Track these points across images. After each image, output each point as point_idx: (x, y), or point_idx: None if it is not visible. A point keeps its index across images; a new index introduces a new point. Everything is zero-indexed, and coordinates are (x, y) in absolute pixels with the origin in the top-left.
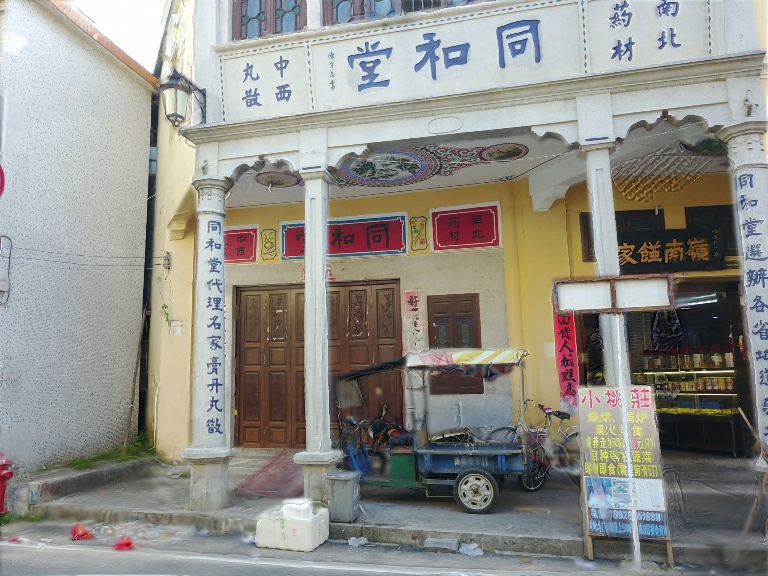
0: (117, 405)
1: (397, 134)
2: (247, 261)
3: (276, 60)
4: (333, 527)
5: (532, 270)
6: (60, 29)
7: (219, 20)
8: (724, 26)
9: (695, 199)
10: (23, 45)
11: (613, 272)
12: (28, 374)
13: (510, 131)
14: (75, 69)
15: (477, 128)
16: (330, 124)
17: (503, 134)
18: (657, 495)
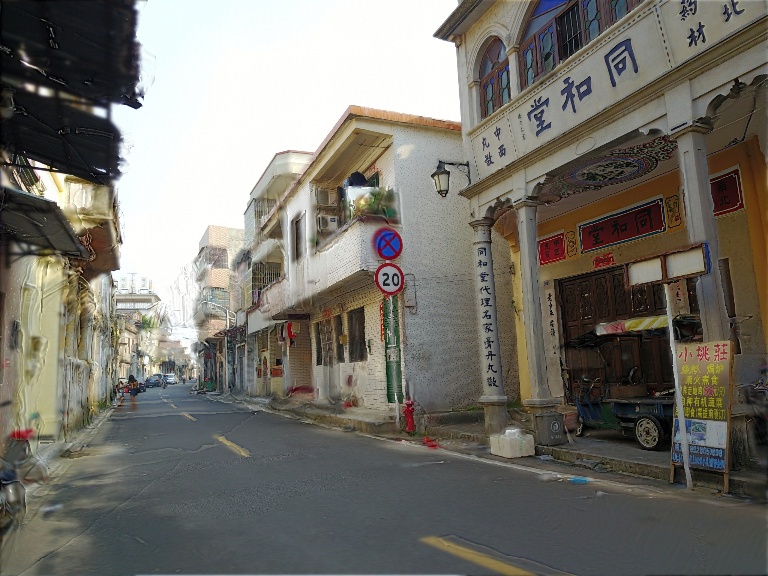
0: (506, 372)
1: (560, 162)
2: (560, 259)
3: (495, 130)
4: (539, 448)
5: None
6: (429, 134)
7: (472, 110)
8: None
9: None
10: (407, 156)
11: (701, 242)
12: (436, 353)
13: (629, 135)
14: (443, 154)
15: (604, 142)
16: (525, 166)
17: (627, 139)
18: (721, 435)
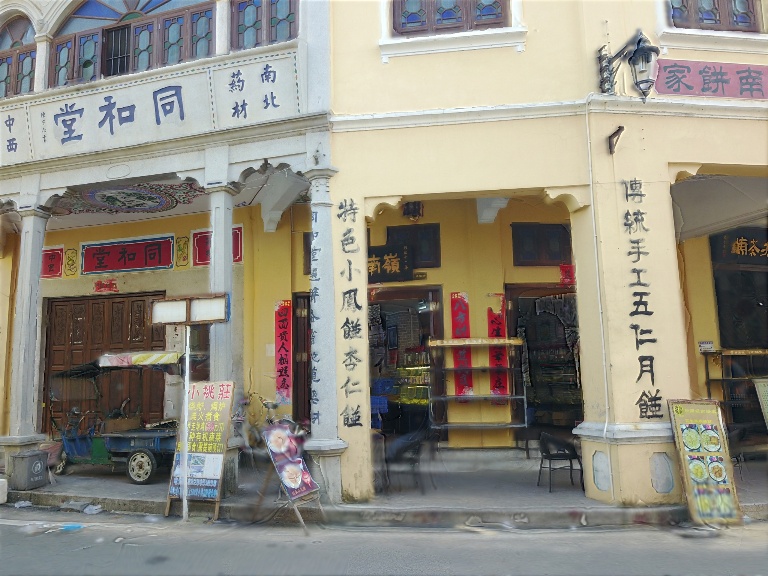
0: None
1: (86, 179)
2: (55, 276)
3: (6, 118)
4: (13, 494)
5: (260, 283)
6: None
7: None
8: (307, 90)
9: (393, 219)
10: None
11: (219, 291)
12: None
13: (166, 176)
14: None
15: (139, 174)
16: (42, 171)
17: (163, 178)
18: (217, 466)
